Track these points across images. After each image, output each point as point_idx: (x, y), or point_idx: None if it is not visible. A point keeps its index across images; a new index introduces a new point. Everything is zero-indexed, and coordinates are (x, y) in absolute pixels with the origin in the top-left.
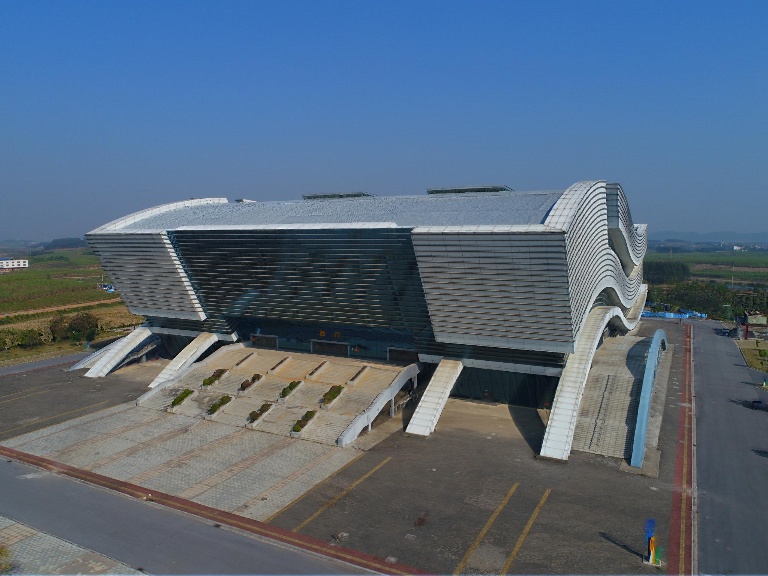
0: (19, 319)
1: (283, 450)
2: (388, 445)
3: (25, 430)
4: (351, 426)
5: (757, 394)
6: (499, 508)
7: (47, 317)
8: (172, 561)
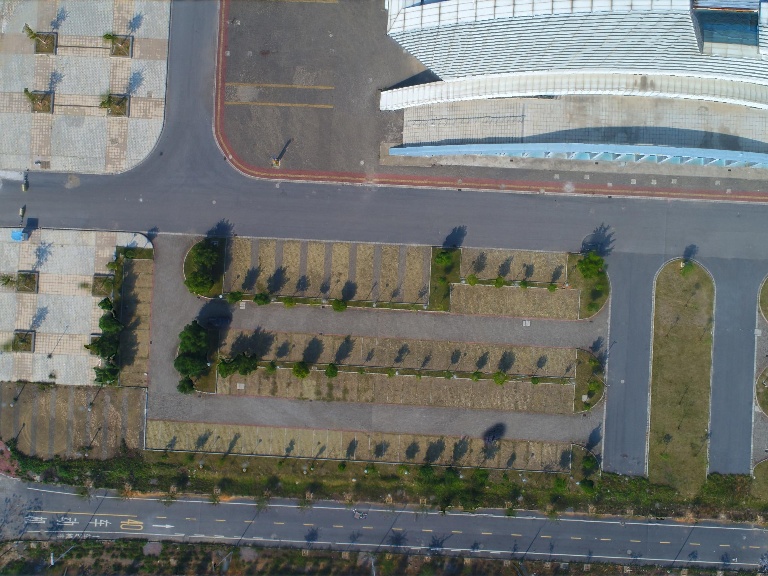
0: None
1: None
2: None
3: None
4: None
5: (646, 253)
6: (297, 86)
7: None
8: None
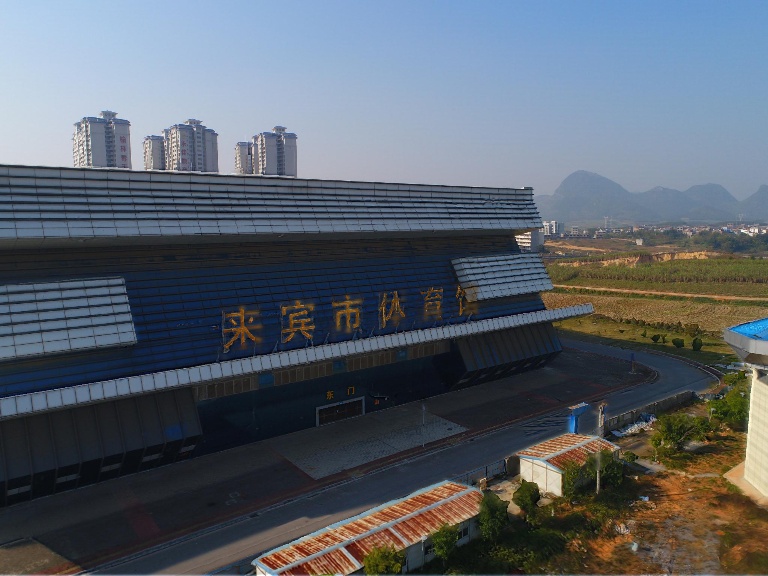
0: (582, 292)
1: None
2: None
3: None
4: None
5: None
6: None
7: (607, 296)
8: None
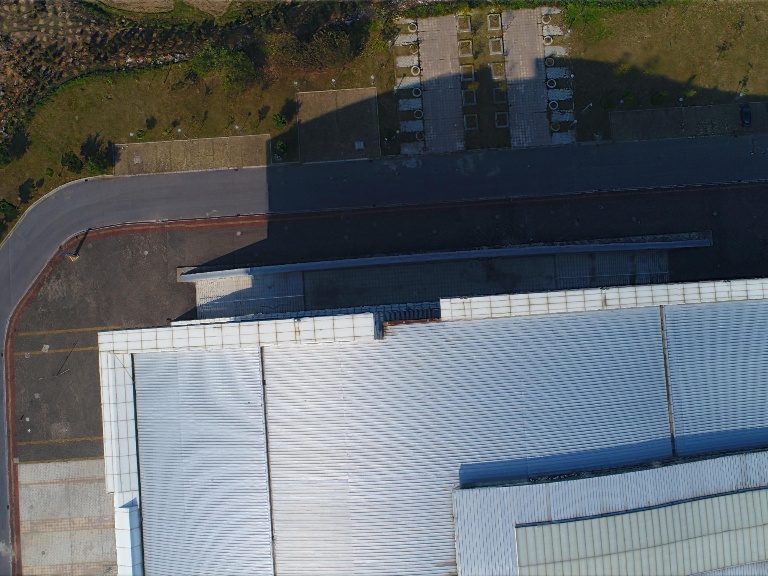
0: None
1: None
2: None
3: (44, 454)
4: None
5: None
6: None
7: None
8: None
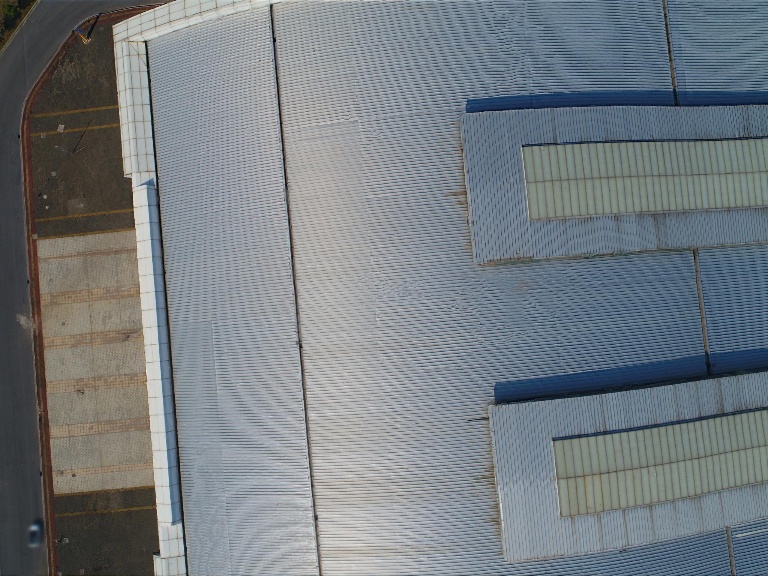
0: None
1: (135, 433)
2: None
3: (62, 229)
4: None
5: None
6: None
7: None
8: (6, 483)
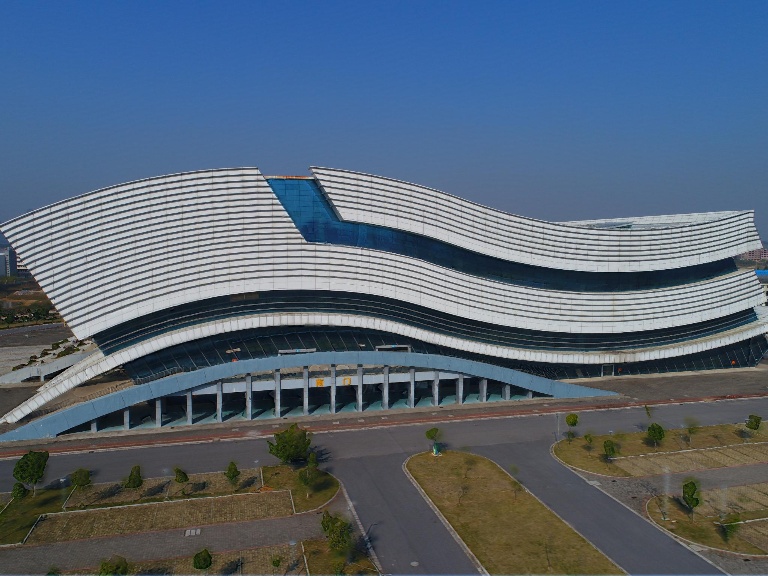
0: None
1: None
2: (10, 389)
3: None
4: (13, 372)
5: (378, 454)
6: None
7: None
8: None
